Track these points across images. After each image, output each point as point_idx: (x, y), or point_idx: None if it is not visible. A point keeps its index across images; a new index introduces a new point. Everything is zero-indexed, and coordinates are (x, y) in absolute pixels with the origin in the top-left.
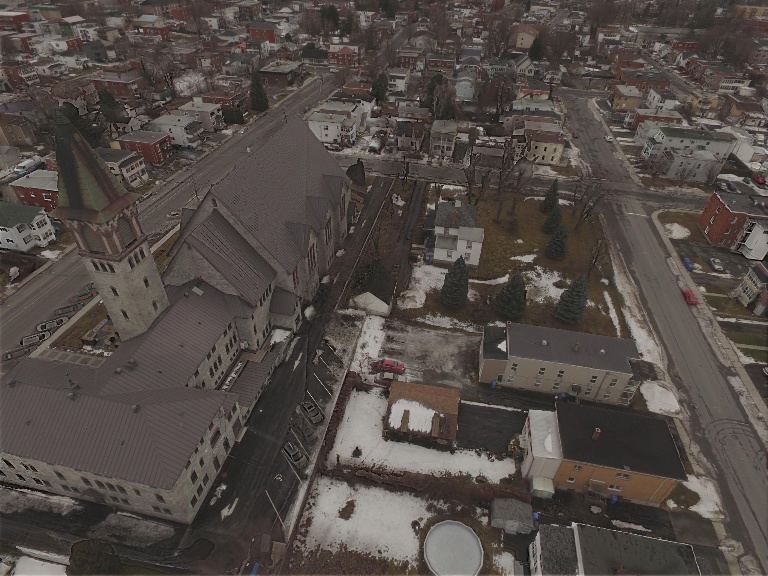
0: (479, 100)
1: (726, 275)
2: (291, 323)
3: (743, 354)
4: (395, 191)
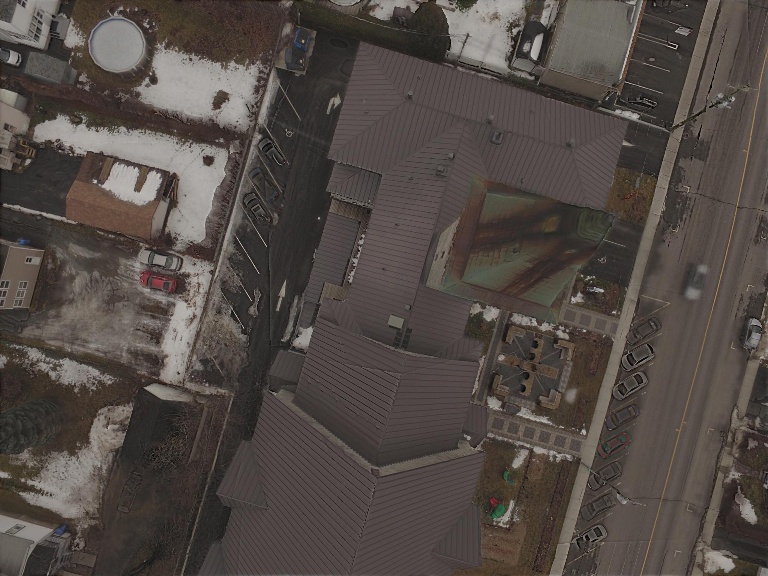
0: None
1: None
2: None
3: None
4: None
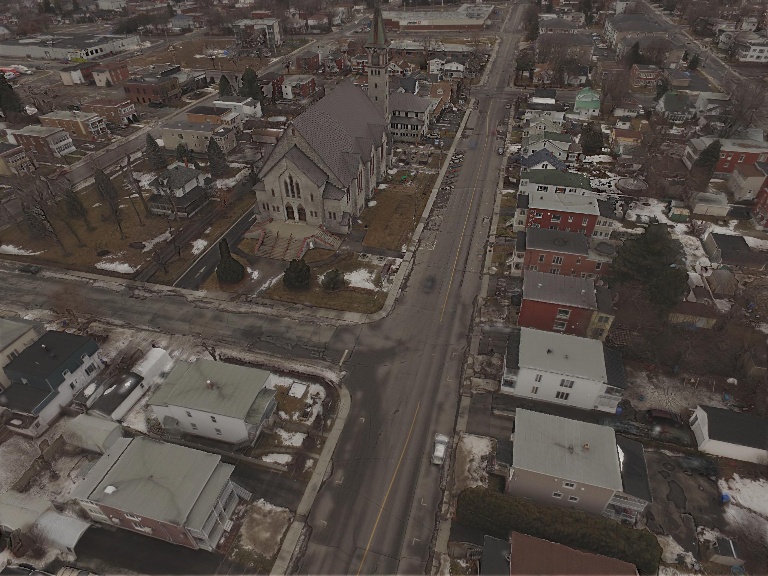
0: None
1: None
2: None
3: None
4: None
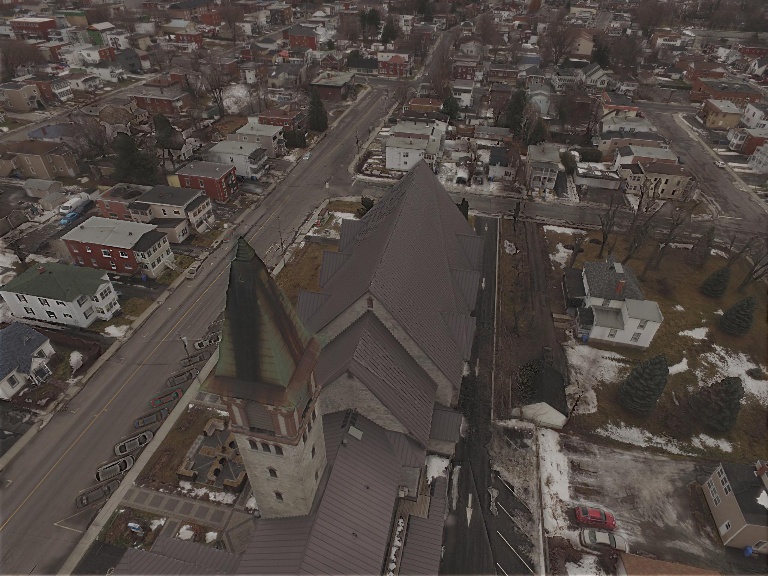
0: (561, 118)
1: None
2: (450, 449)
3: None
4: (505, 236)
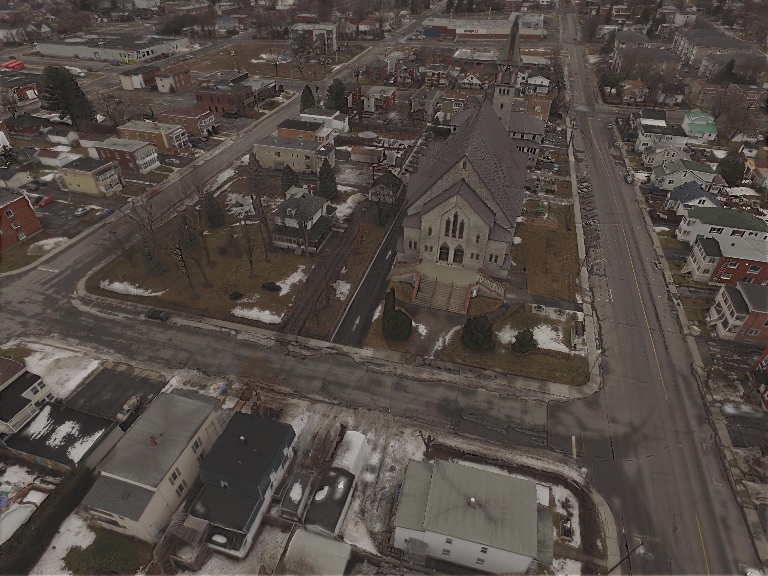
0: None
1: (90, 206)
2: None
3: (175, 170)
4: None
